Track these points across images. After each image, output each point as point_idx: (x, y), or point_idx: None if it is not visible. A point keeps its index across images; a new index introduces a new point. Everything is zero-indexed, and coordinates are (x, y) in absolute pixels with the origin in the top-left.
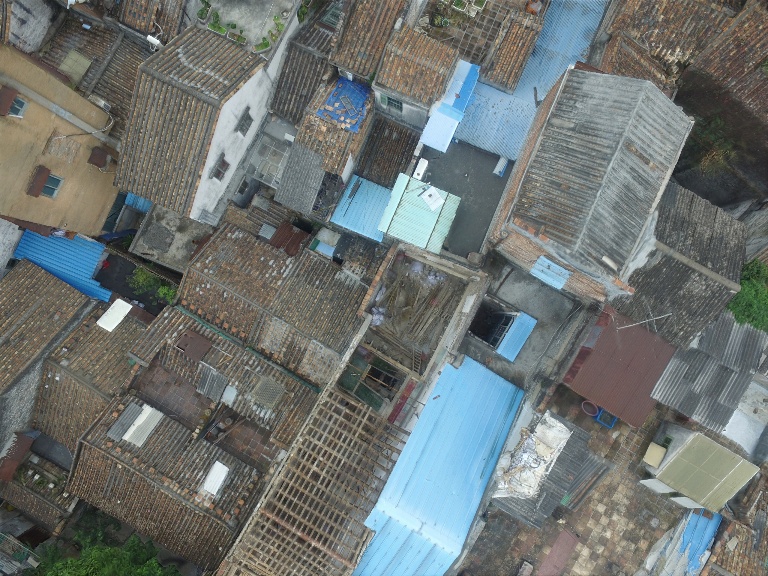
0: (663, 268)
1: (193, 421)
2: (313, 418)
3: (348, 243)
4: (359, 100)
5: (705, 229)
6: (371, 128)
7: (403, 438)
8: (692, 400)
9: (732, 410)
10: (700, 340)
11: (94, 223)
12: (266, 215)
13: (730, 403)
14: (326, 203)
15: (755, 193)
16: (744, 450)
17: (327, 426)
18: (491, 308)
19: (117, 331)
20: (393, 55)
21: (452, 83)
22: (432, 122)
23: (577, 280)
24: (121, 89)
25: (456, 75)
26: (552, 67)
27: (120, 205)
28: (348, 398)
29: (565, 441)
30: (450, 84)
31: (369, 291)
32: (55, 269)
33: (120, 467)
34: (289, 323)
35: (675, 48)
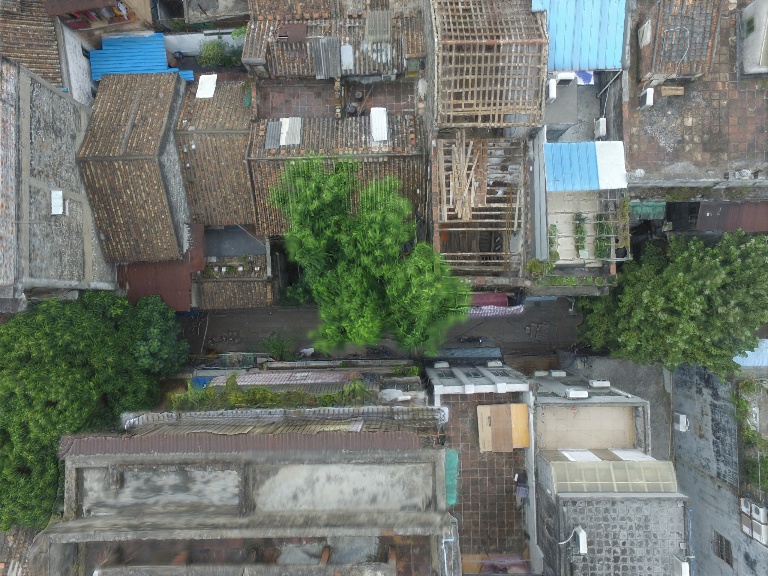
0: None
1: None
2: None
3: None
4: None
5: None
6: None
7: None
8: None
9: None
10: None
11: (144, 7)
12: None
13: None
14: None
15: None
16: None
17: None
18: None
19: (217, 95)
20: None
21: None
22: None
23: None
24: None
25: None
26: None
27: (154, 3)
28: None
29: None
30: None
31: None
32: None
33: (294, 163)
34: None
35: None
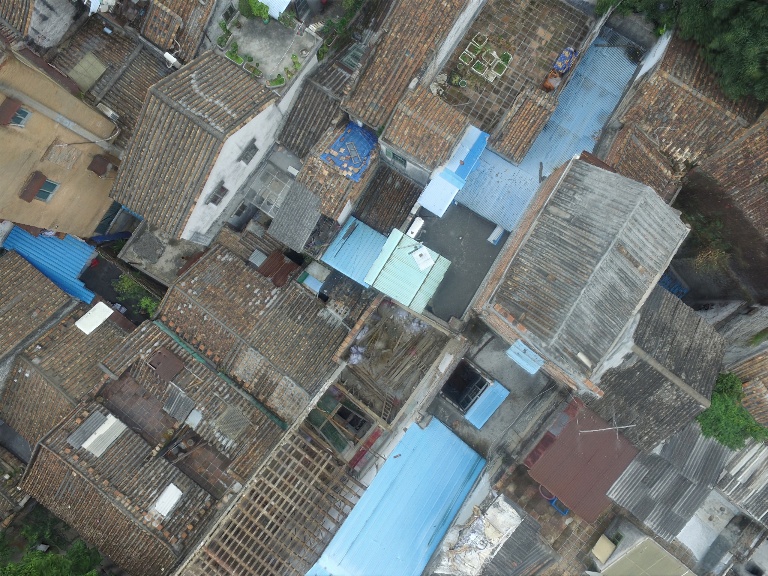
0: (637, 372)
1: (156, 436)
2: (271, 460)
3: (336, 281)
4: (365, 148)
5: (685, 338)
6: (375, 174)
7: (358, 491)
8: (647, 505)
9: (685, 521)
10: (663, 447)
11: (87, 225)
12: (259, 241)
13: (684, 514)
14: (318, 244)
15: (745, 295)
16: (694, 555)
17: (284, 470)
18: (469, 365)
19: (94, 334)
20: (403, 114)
21: (458, 149)
22: (432, 186)
23: (552, 366)
24: (132, 99)
25: (464, 141)
26: (561, 144)
27: (116, 208)
28: (310, 443)
29: (515, 527)
30: (456, 149)
31: (347, 338)
32: (42, 264)
33: (75, 475)
34: (264, 356)
35: (685, 147)
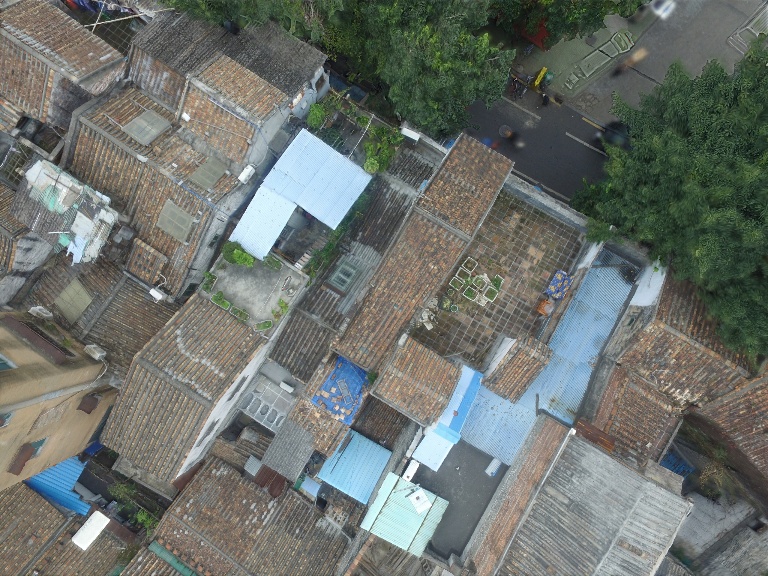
0: None
1: None
2: None
3: None
4: (357, 384)
5: None
6: None
7: None
8: None
9: None
10: None
11: (79, 444)
12: (254, 446)
13: None
14: (313, 474)
15: (753, 503)
16: None
17: None
18: None
19: (91, 549)
20: (393, 375)
21: (452, 397)
22: (426, 441)
23: None
24: (120, 326)
25: (457, 386)
26: (557, 373)
27: None
28: None
29: None
30: None
31: (346, 575)
32: (36, 480)
33: None
34: None
35: (684, 389)
